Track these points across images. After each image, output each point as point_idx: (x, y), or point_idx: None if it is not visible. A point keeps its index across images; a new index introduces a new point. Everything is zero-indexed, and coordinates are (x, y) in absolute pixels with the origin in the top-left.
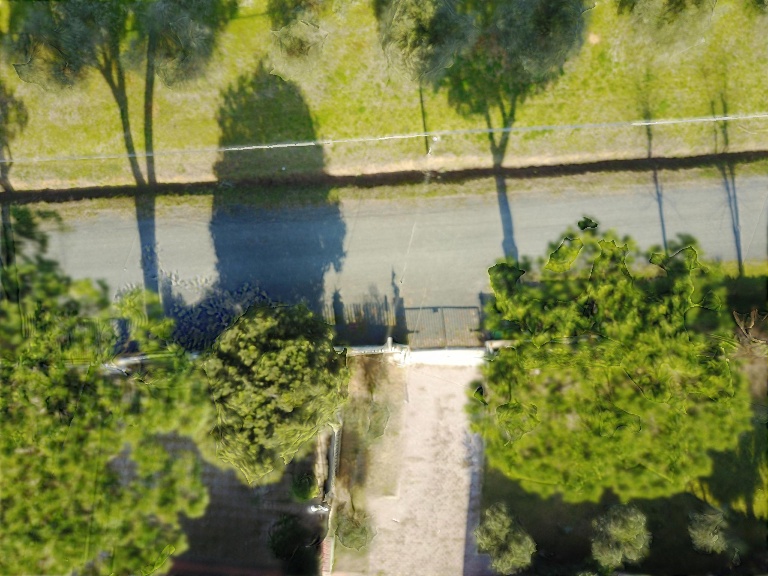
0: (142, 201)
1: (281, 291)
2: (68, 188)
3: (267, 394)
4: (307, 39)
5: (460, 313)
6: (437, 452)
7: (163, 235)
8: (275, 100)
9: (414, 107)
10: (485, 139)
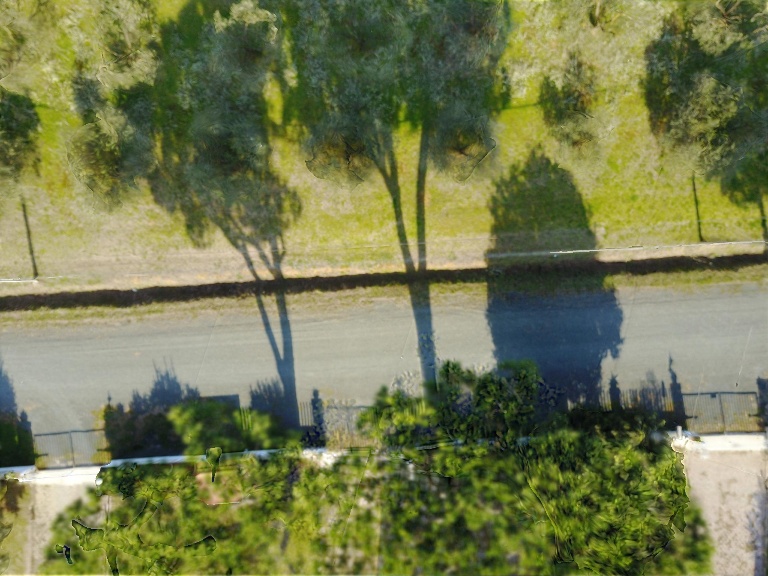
0: (416, 289)
1: (558, 378)
2: (337, 276)
3: (642, 507)
4: (598, 134)
5: (738, 398)
6: (720, 537)
7: (439, 323)
8: (547, 189)
9: (687, 195)
10: (758, 226)
